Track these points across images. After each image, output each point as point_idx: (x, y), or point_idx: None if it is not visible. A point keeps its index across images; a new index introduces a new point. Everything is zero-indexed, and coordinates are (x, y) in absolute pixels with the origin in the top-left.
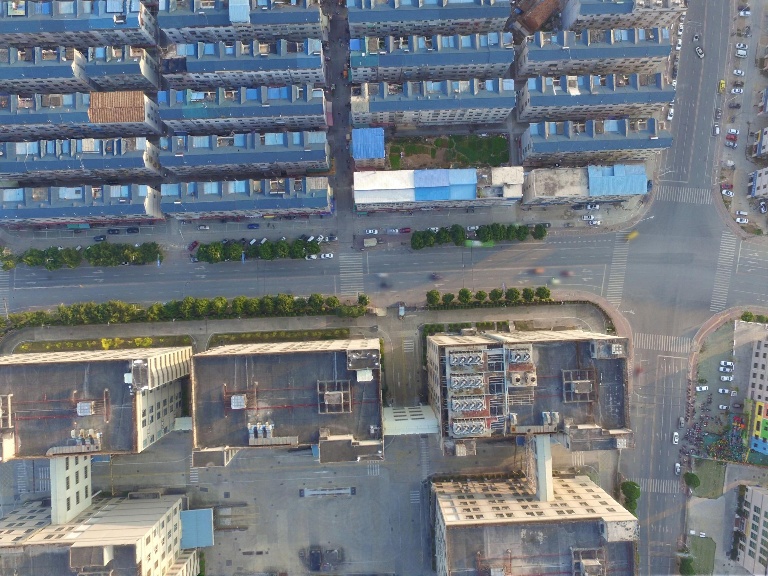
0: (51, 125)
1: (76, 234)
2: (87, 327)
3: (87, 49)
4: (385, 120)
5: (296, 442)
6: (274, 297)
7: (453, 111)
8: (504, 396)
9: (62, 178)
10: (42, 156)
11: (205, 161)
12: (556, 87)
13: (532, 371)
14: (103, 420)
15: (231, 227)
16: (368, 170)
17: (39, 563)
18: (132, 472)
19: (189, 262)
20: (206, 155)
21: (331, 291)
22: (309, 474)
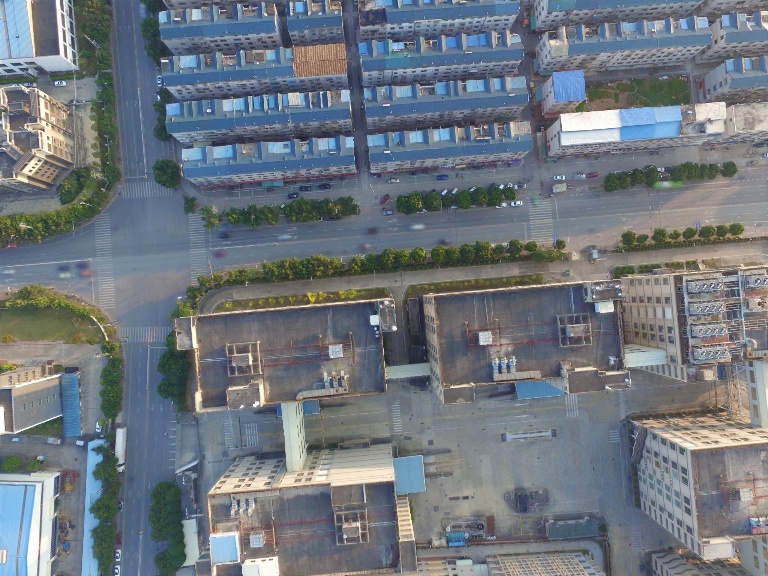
0: (254, 81)
1: (268, 193)
2: (284, 284)
3: (288, 4)
4: (573, 65)
5: (539, 376)
6: (473, 245)
7: (647, 51)
8: (740, 322)
9: (256, 136)
10: (250, 112)
11: (410, 110)
12: (750, 23)
13: (767, 296)
14: (349, 363)
15: (420, 179)
16: (556, 116)
17: (294, 505)
18: (337, 424)
19: (381, 215)
20: (412, 104)
21: (522, 238)
22: (510, 419)
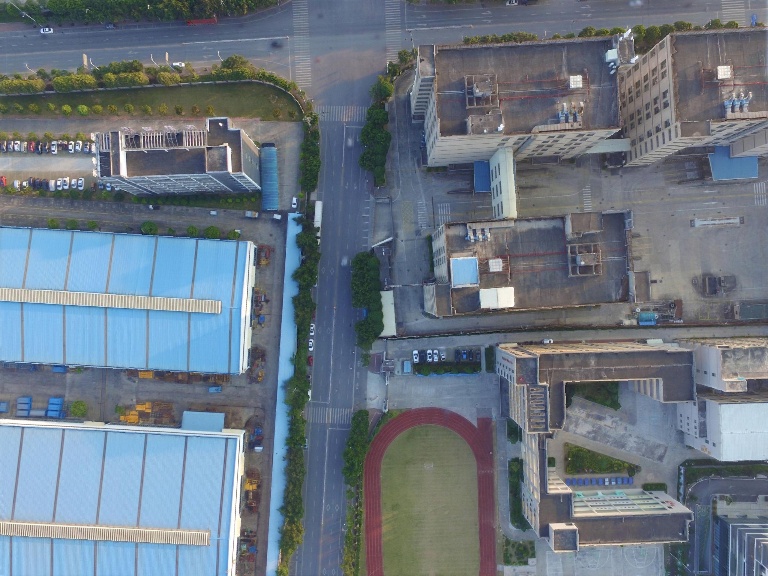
0: None
1: None
2: None
3: None
4: None
5: None
6: None
7: None
8: None
9: None
10: None
11: None
12: None
13: None
14: (583, 100)
15: None
16: None
17: (527, 238)
18: (528, 206)
19: (575, 1)
20: None
21: None
22: (699, 205)
